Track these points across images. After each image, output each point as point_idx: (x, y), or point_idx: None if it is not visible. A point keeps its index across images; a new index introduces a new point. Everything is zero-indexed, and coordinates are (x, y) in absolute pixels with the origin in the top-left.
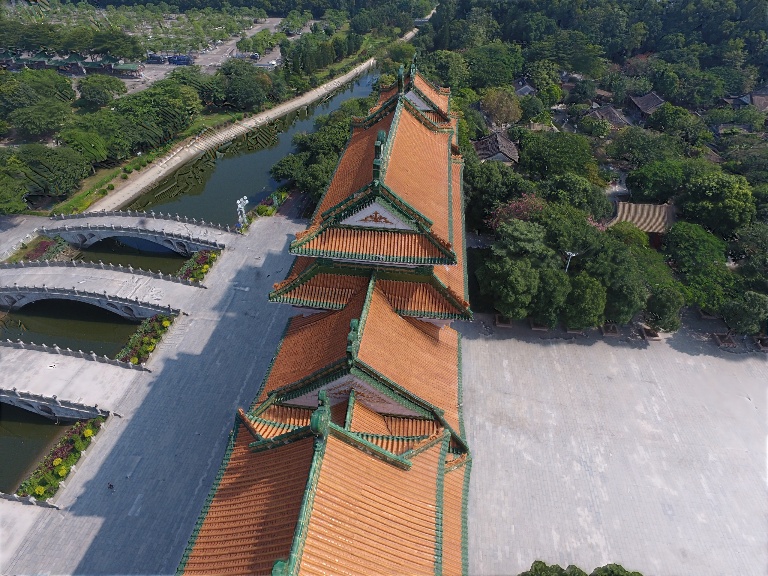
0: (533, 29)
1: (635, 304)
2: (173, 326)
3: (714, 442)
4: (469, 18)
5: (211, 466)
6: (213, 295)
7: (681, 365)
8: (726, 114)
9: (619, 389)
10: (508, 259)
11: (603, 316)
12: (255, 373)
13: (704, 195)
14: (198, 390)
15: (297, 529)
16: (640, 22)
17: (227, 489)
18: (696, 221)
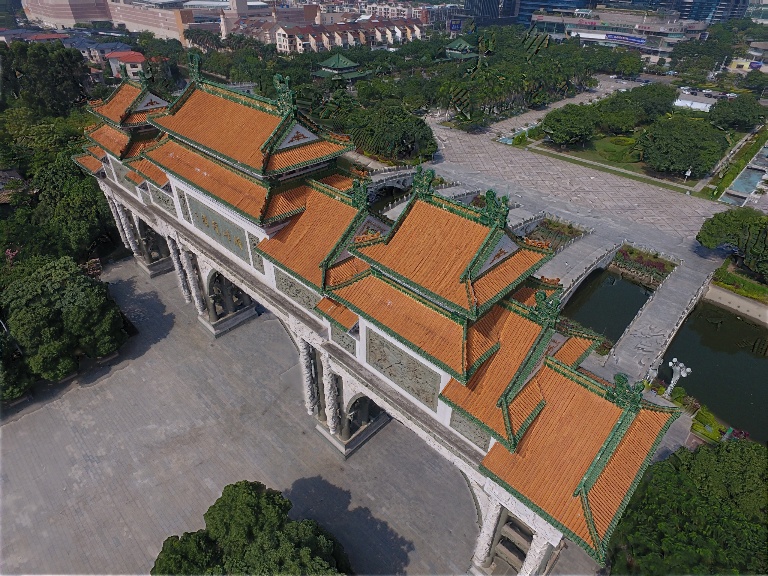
0: None
1: None
2: None
3: None
4: None
5: None
6: None
7: None
8: None
9: None
10: (271, 509)
11: None
12: None
13: None
14: None
15: None
16: None
17: None
18: None
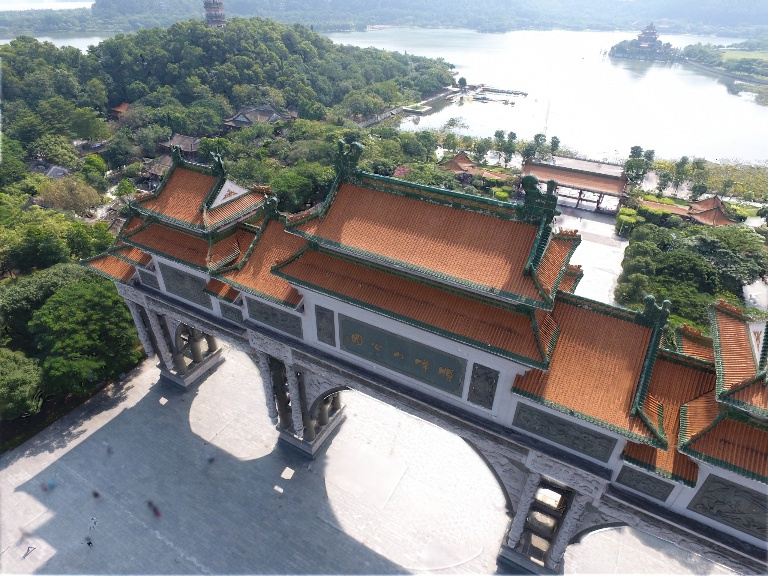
0: None
1: None
2: None
3: None
4: None
5: None
6: None
7: None
8: (249, 132)
9: None
10: None
11: None
12: None
13: None
14: None
15: None
16: (93, 78)
17: None
18: None
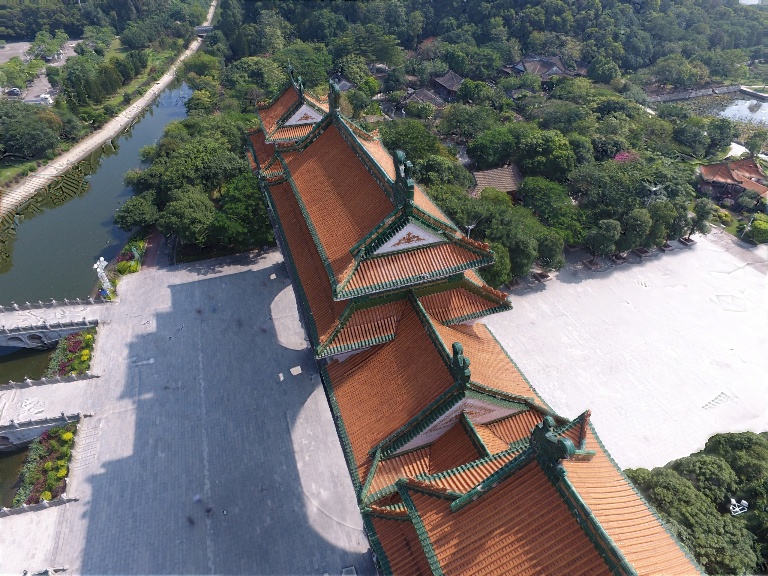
0: (326, 26)
1: (532, 255)
2: (79, 436)
3: (623, 345)
4: (261, 21)
5: (215, 569)
6: (112, 382)
7: (575, 294)
8: (513, 81)
9: (544, 330)
10: None
11: (510, 273)
12: (212, 447)
13: (536, 151)
14: (152, 494)
15: (619, 553)
16: (416, 11)
17: (453, 561)
18: (534, 174)
